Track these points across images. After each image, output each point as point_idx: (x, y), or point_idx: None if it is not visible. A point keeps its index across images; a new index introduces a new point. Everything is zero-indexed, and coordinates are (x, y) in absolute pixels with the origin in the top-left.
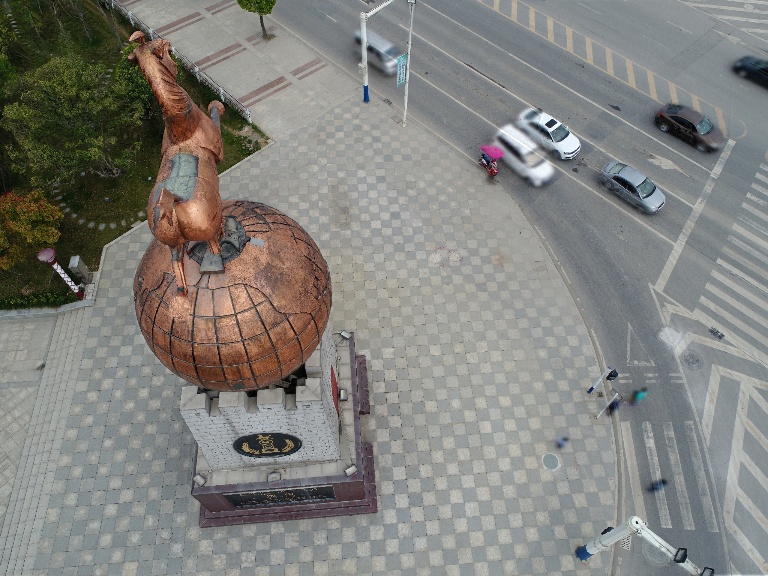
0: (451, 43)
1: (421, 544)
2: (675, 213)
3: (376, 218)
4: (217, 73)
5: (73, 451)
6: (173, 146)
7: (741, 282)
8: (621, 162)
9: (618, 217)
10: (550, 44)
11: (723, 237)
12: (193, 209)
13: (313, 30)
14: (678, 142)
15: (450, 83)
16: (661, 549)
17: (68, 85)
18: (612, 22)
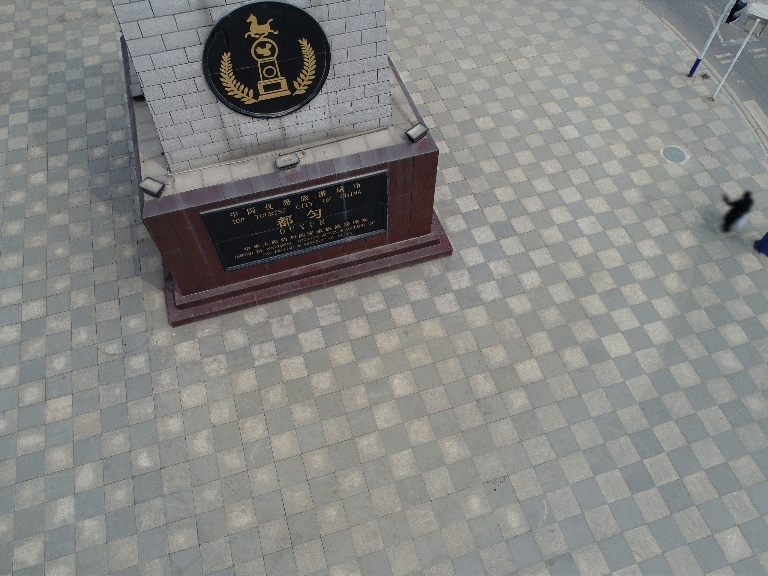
0: None
1: (532, 280)
2: None
3: None
4: None
5: None
6: None
7: None
8: None
9: None
10: None
11: None
12: None
13: None
14: None
15: None
16: None
17: None
18: None
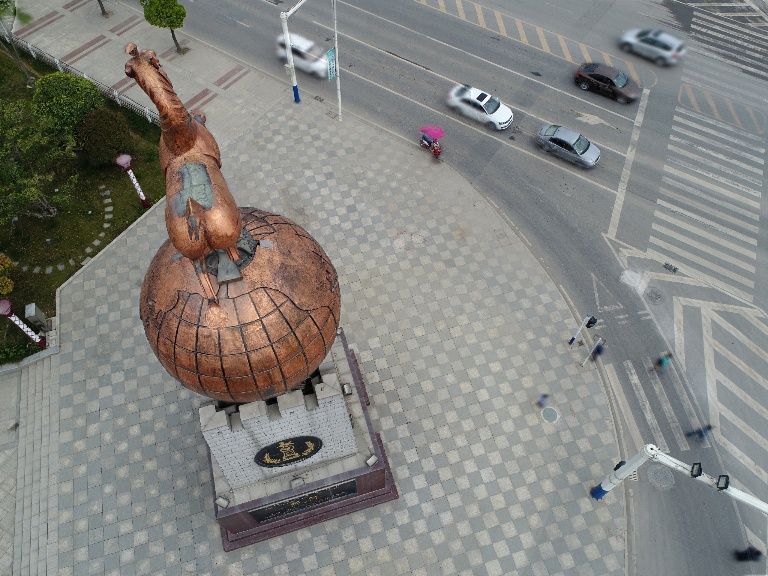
0: (368, 33)
1: (447, 518)
2: (611, 164)
3: (333, 214)
4: (137, 94)
5: (72, 505)
6: (177, 158)
7: (682, 217)
8: (552, 124)
9: (561, 176)
10: (463, 22)
11: (657, 179)
12: (218, 216)
13: (227, 38)
14: (599, 98)
15: (376, 72)
16: (678, 468)
17: None
18: None
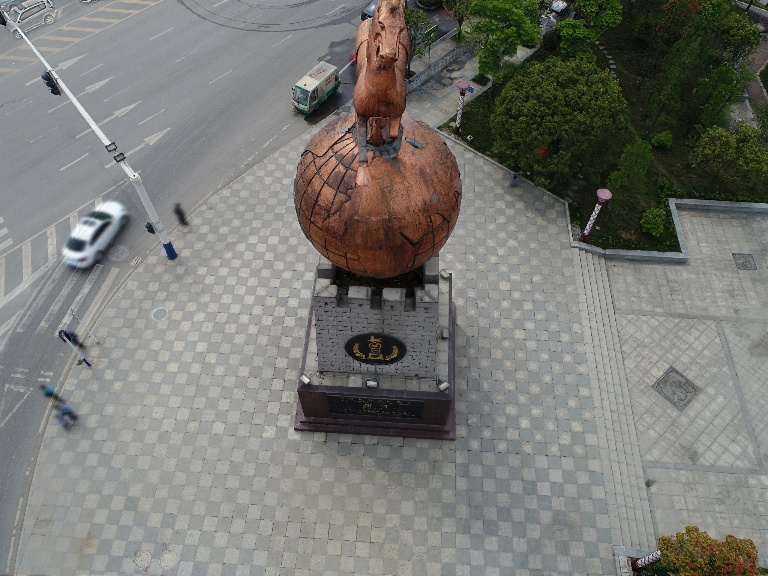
0: None
1: (287, 274)
2: None
3: None
4: None
5: (577, 376)
6: None
7: None
8: None
9: None
10: None
11: None
12: None
13: None
14: None
15: None
16: None
17: None
18: None
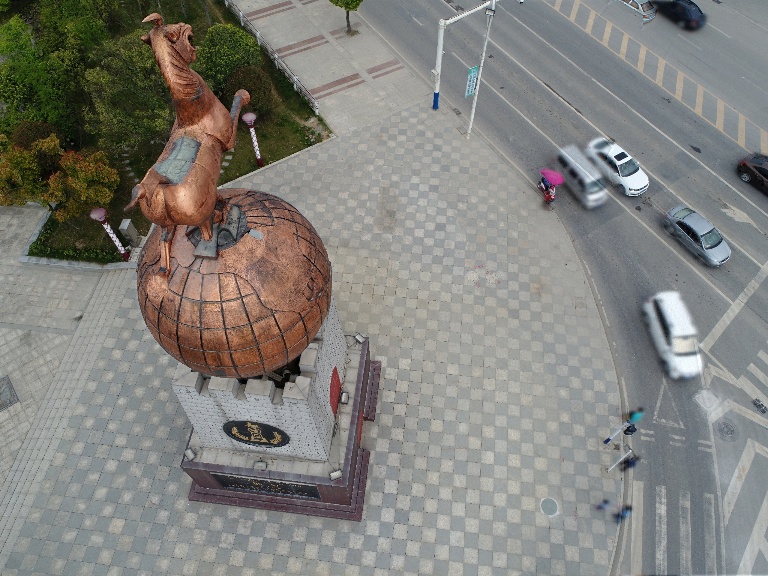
0: (534, 60)
1: (398, 563)
2: (740, 270)
3: (421, 226)
4: (296, 62)
5: (89, 403)
6: (179, 129)
7: None
8: (690, 207)
9: (675, 264)
10: (638, 74)
11: None
12: (180, 193)
13: (397, 31)
14: (759, 195)
15: (524, 101)
16: None
17: (145, 56)
18: (711, 59)
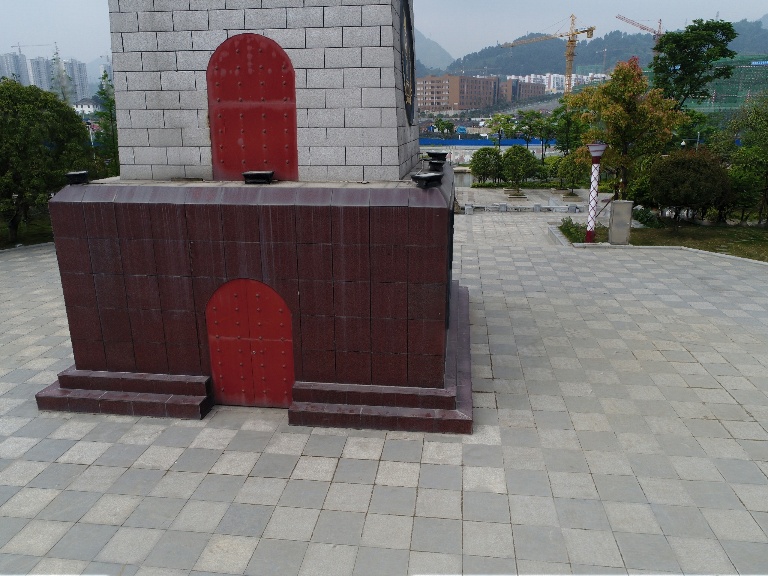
0: None
1: None
2: None
3: None
4: None
5: None
6: None
7: None
8: None
9: None
10: None
11: None
12: None
13: None
14: None
15: None
16: None
17: None
18: None
